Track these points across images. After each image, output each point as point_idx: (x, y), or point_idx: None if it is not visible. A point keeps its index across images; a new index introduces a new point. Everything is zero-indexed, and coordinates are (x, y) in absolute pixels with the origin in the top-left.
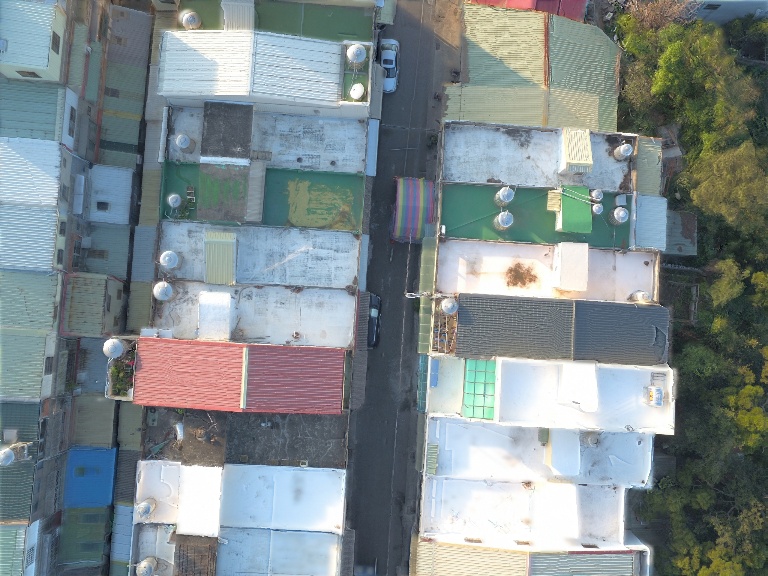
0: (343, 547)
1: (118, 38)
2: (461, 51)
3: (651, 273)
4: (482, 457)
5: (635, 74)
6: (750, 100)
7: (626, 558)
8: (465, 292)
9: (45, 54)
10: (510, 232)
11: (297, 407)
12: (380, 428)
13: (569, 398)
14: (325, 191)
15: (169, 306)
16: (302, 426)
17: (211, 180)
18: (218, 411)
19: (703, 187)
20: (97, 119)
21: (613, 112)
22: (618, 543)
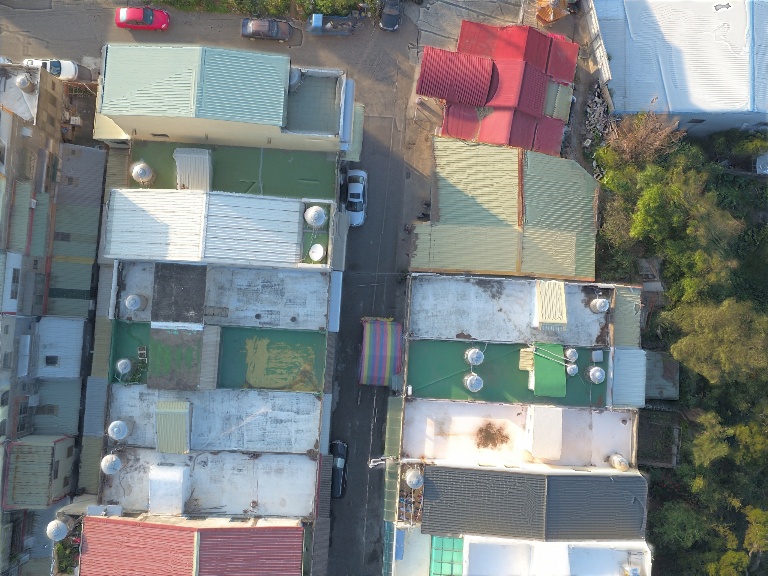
0: None
1: (69, 178)
2: (431, 187)
3: (629, 433)
4: None
5: (614, 211)
6: (735, 234)
7: None
8: (433, 455)
9: None
10: (480, 391)
11: None
12: None
13: None
14: (285, 349)
15: (120, 474)
16: None
17: (162, 346)
18: None
19: (684, 345)
20: (45, 268)
21: (591, 252)
22: None
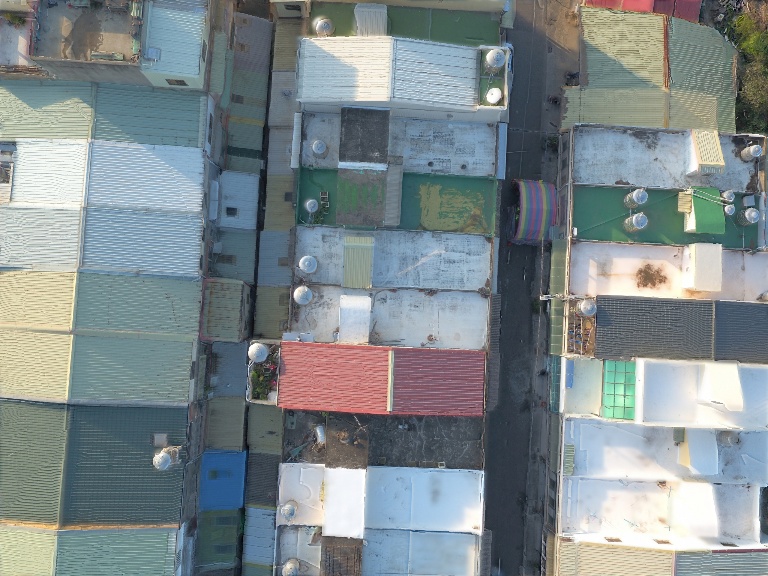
0: (481, 547)
1: (241, 45)
2: (579, 54)
3: None
4: (616, 457)
5: (752, 75)
6: None
7: (766, 556)
8: (596, 293)
9: (196, 62)
10: (639, 233)
11: (441, 409)
12: (501, 429)
13: (710, 398)
14: (456, 195)
15: (305, 310)
16: (438, 428)
17: (349, 185)
18: (361, 414)
19: None
20: (225, 125)
21: (732, 113)
22: (754, 541)
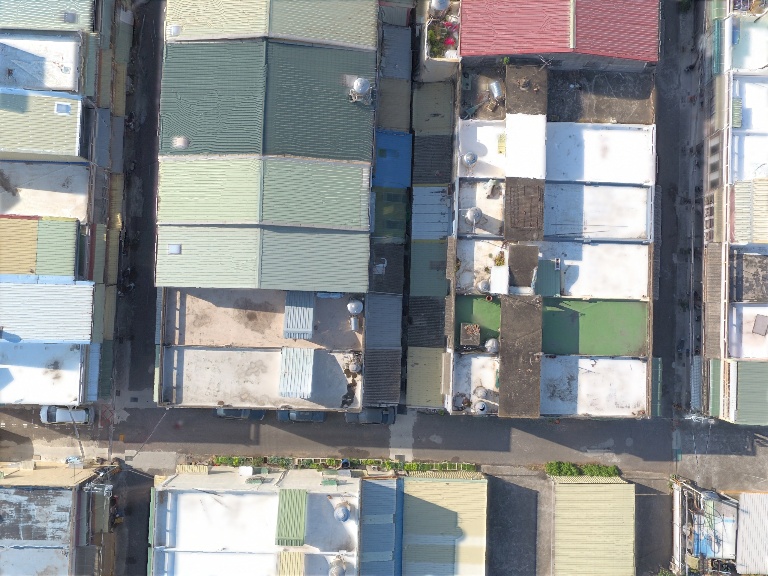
0: None
1: None
2: None
3: None
4: None
5: None
6: None
7: None
8: None
9: None
10: None
11: (620, 51)
12: None
13: None
14: None
15: None
16: (608, 88)
17: None
18: (540, 62)
19: None
20: None
21: None
22: None
